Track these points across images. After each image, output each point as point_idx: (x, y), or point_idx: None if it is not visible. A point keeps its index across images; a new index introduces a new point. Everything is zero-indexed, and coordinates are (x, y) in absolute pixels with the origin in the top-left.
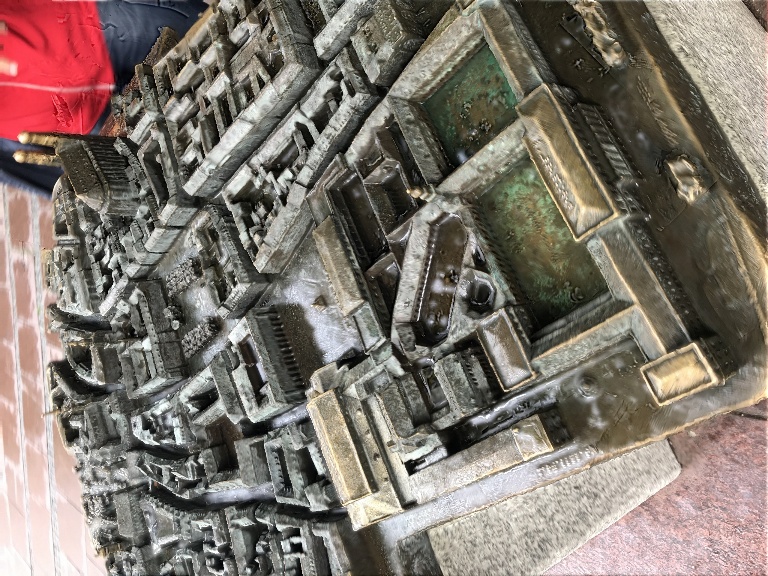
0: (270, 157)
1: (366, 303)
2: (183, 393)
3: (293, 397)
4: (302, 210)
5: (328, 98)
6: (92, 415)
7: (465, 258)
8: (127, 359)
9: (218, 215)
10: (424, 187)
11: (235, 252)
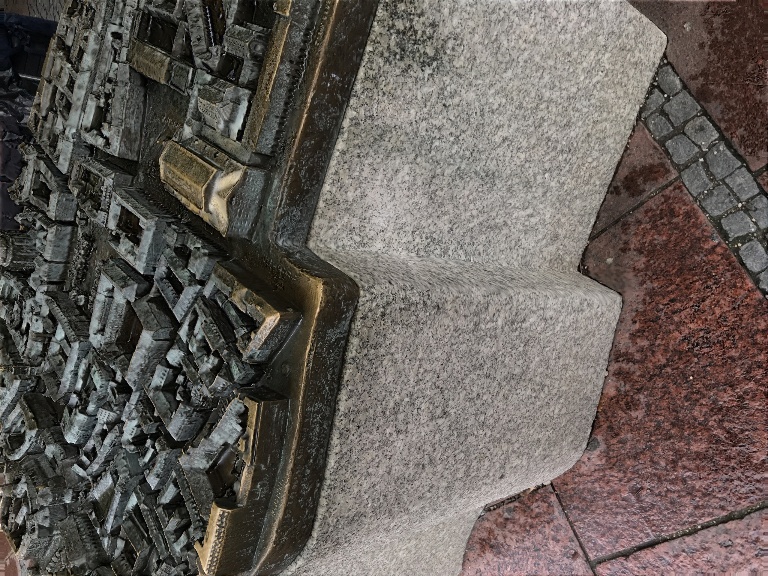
0: (104, 76)
1: (174, 62)
2: (91, 330)
3: (163, 216)
4: (132, 84)
5: (125, 1)
6: (29, 469)
7: None
8: (49, 374)
9: (84, 158)
10: None
11: (99, 166)
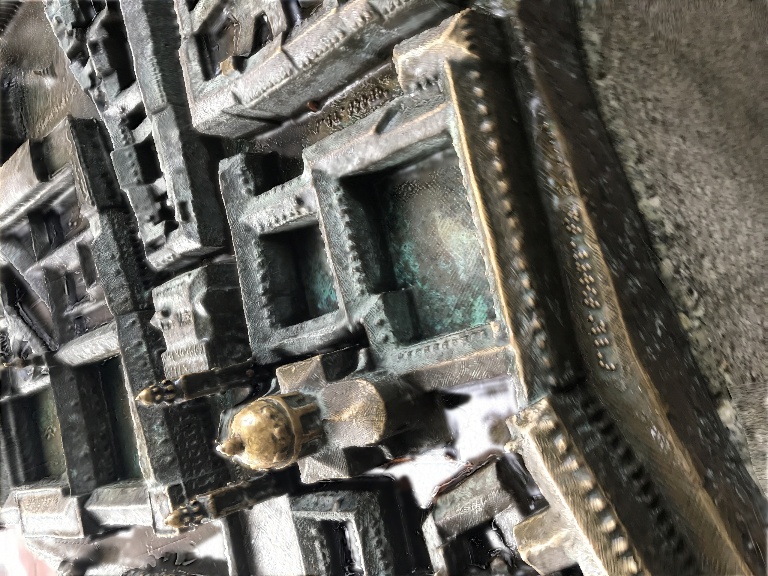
0: None
1: None
2: None
3: None
4: None
5: None
6: None
7: None
8: None
9: None
10: (33, 366)
11: None
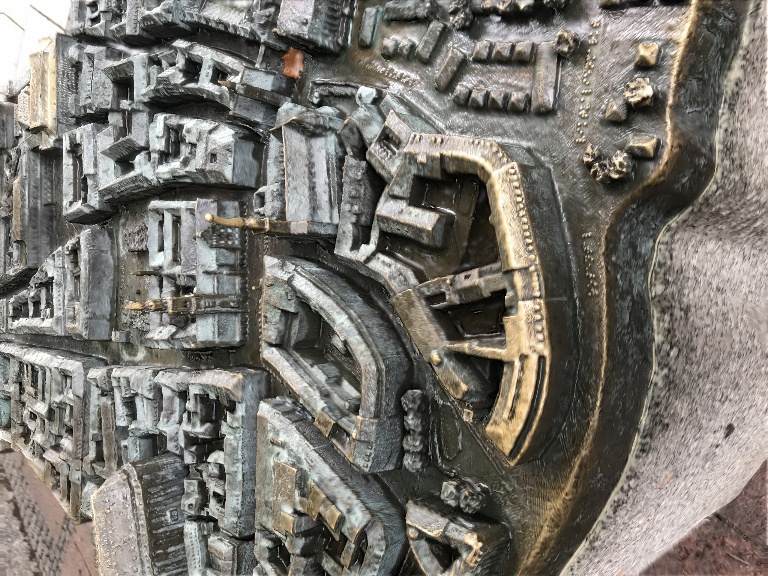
0: None
1: None
2: None
3: None
4: None
5: None
6: None
7: (8, 184)
8: None
9: None
10: None
11: None
